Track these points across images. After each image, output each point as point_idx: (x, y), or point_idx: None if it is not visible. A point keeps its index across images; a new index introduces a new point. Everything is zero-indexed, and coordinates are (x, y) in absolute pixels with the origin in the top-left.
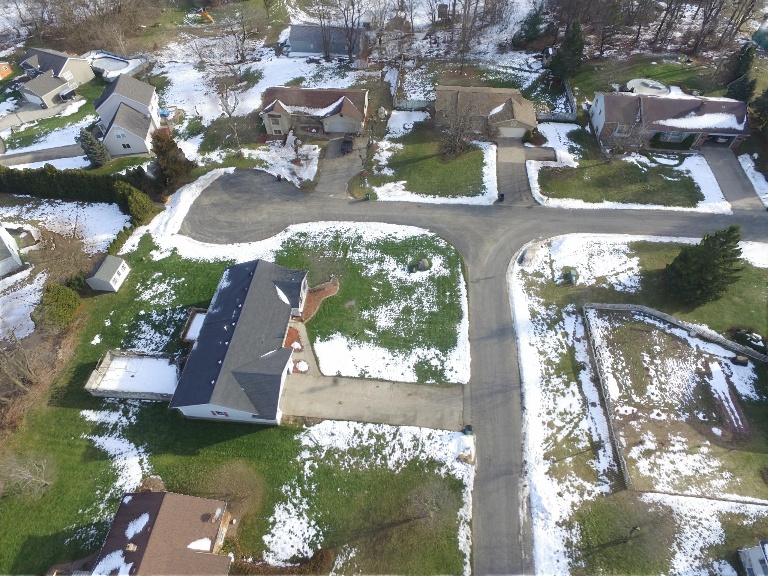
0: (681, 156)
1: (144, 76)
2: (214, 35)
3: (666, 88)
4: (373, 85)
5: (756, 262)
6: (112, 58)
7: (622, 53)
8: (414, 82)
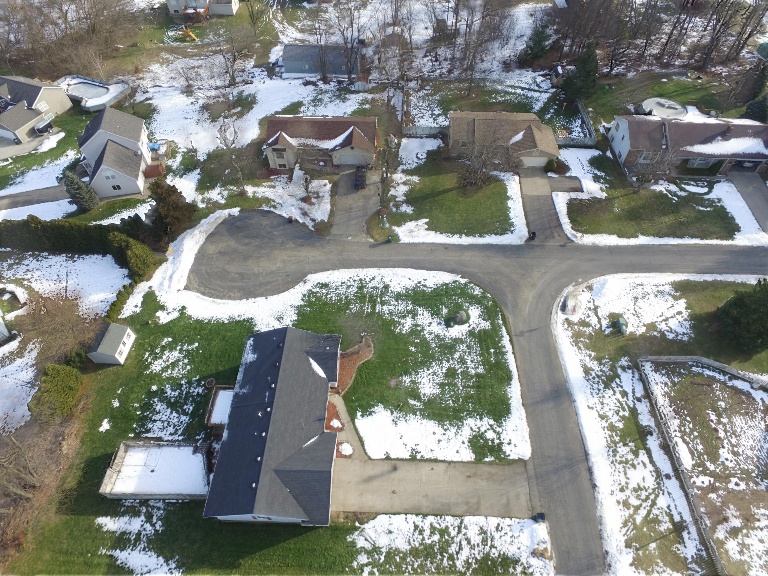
0: (710, 183)
1: (127, 104)
2: (199, 55)
3: (682, 108)
4: (378, 110)
5: None
6: (89, 83)
7: (631, 70)
8: (420, 105)
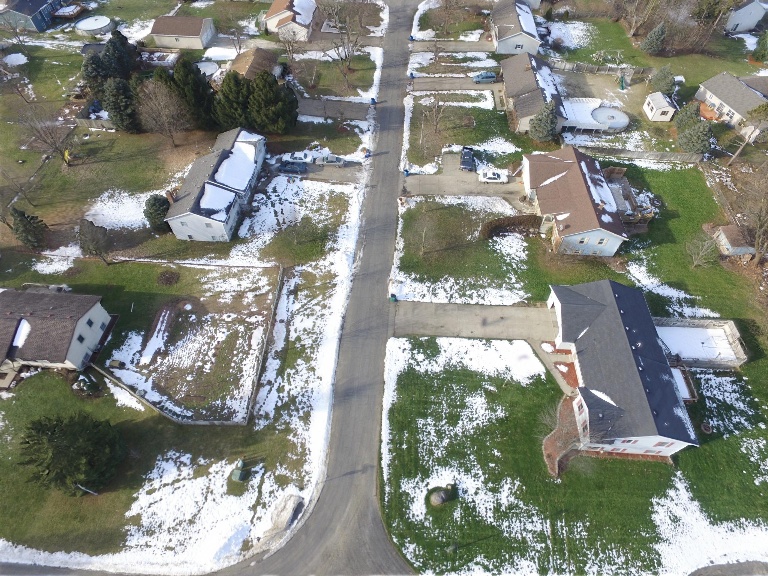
0: None
1: None
2: None
3: None
4: None
5: None
6: None
7: None
8: None
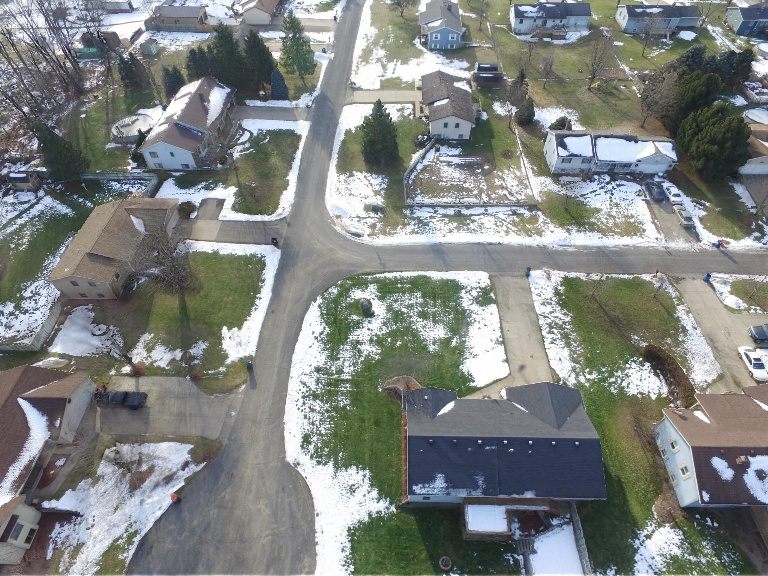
0: (240, 129)
1: None
2: None
3: (138, 116)
4: None
5: (358, 123)
6: None
7: None
8: None
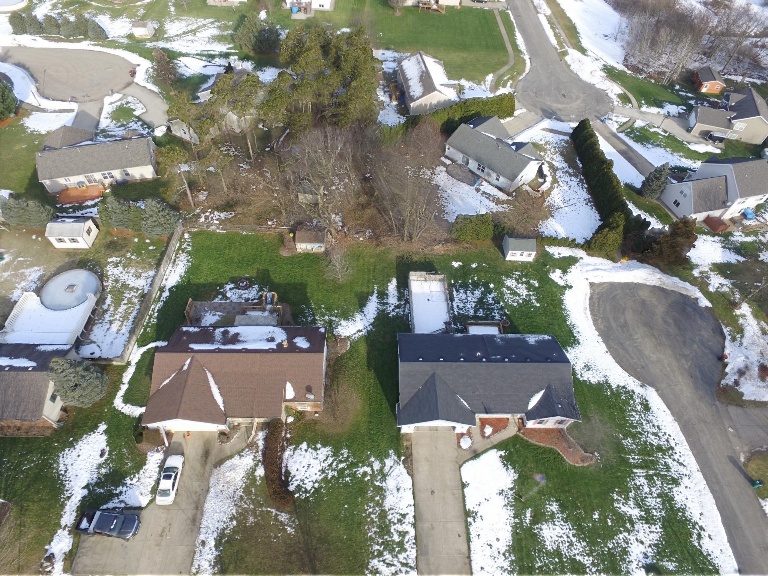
0: None
1: None
2: None
3: None
4: None
5: None
6: None
7: None
8: None
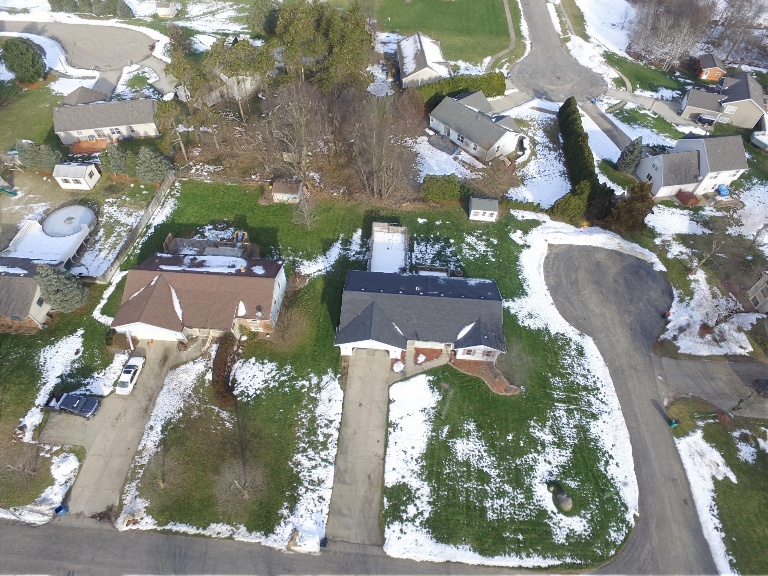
0: None
1: None
2: None
3: None
4: None
5: None
6: None
7: None
8: None
